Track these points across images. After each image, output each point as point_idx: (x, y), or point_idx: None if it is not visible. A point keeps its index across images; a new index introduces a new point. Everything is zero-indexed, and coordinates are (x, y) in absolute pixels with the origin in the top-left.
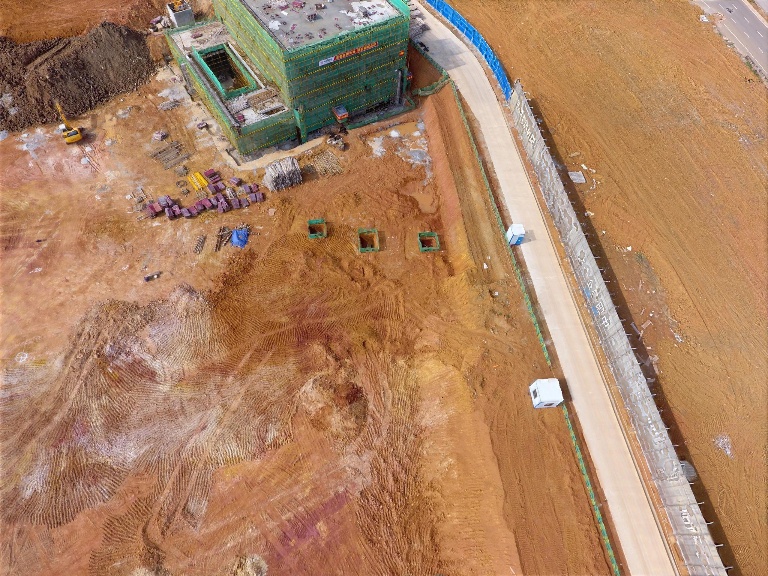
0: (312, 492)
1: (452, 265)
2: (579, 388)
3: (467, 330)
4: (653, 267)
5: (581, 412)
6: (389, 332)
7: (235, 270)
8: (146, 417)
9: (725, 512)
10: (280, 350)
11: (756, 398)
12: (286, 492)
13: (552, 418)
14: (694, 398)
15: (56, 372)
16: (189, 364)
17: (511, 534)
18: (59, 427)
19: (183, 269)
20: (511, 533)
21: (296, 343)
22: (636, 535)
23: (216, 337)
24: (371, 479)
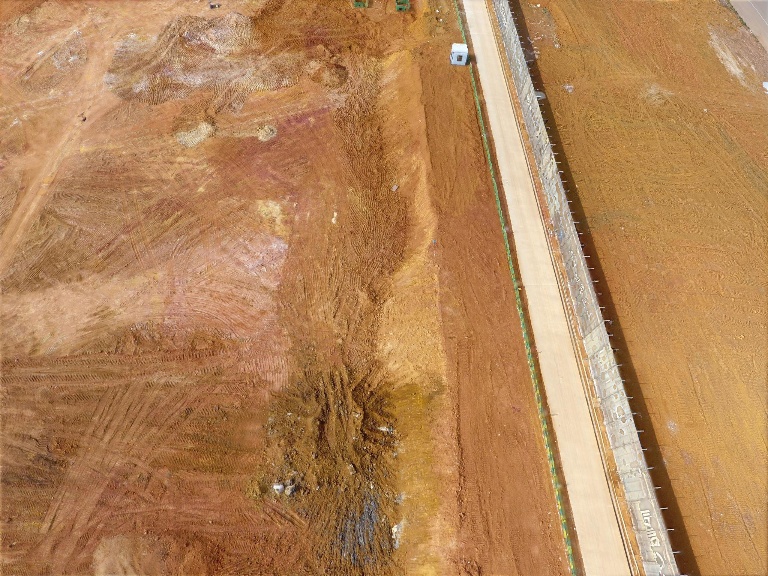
0: (308, 106)
1: (417, 18)
2: (483, 59)
3: (418, 40)
4: (552, 15)
5: (481, 68)
6: (368, 45)
7: (269, 7)
8: (208, 67)
9: (558, 112)
10: (295, 47)
11: (598, 73)
12: (292, 105)
13: (461, 69)
14: (556, 68)
15: (153, 43)
16: (236, 48)
17: (422, 106)
18: (155, 67)
19: (235, 4)
20: (423, 106)
21: (306, 45)
22: (500, 116)
23: (254, 38)
24: (345, 105)
